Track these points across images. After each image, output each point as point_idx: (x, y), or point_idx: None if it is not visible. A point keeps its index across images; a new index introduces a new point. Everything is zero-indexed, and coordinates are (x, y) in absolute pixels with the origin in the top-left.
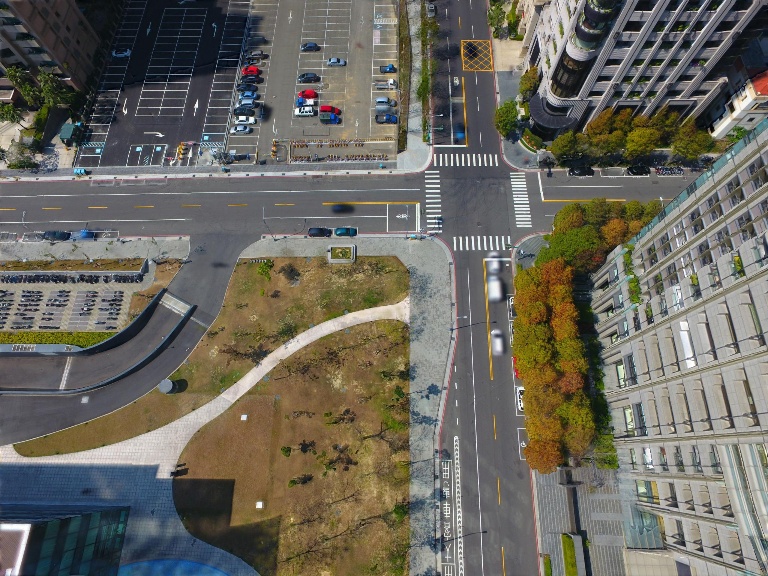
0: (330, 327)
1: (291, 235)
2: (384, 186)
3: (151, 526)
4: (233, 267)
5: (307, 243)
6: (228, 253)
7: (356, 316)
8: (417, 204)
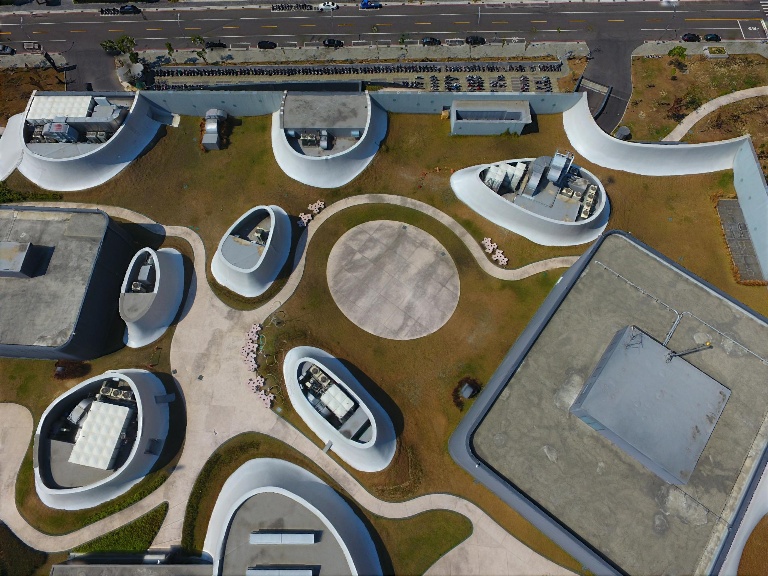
0: (725, 100)
1: (668, 41)
2: (730, 8)
3: None
4: (630, 62)
5: (684, 46)
6: (622, 52)
7: (743, 93)
8: (761, 20)
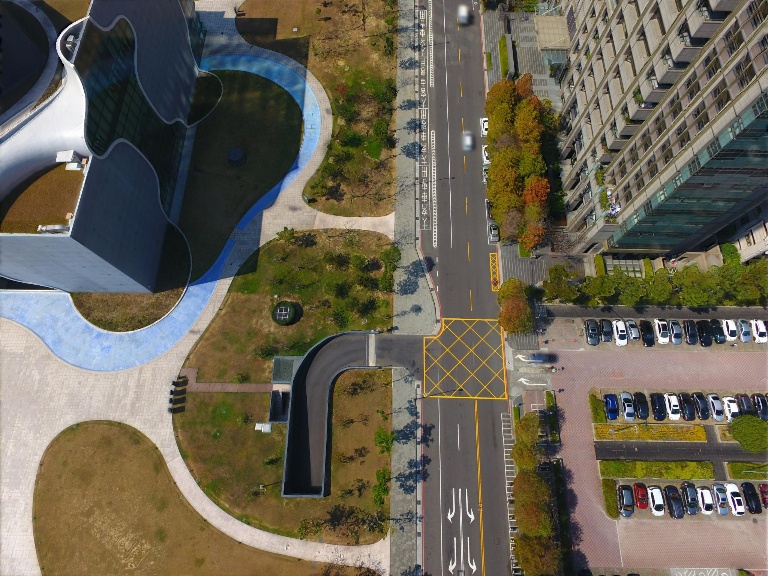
0: None
1: None
2: None
3: (222, 40)
4: None
5: None
6: None
7: None
8: None
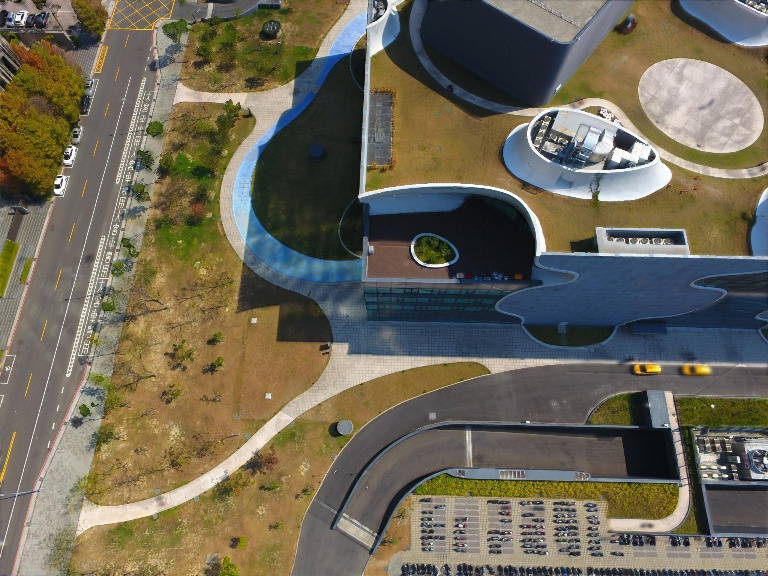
0: (176, 497)
1: None
2: None
3: (347, 306)
4: None
5: None
6: None
7: (144, 511)
8: None
